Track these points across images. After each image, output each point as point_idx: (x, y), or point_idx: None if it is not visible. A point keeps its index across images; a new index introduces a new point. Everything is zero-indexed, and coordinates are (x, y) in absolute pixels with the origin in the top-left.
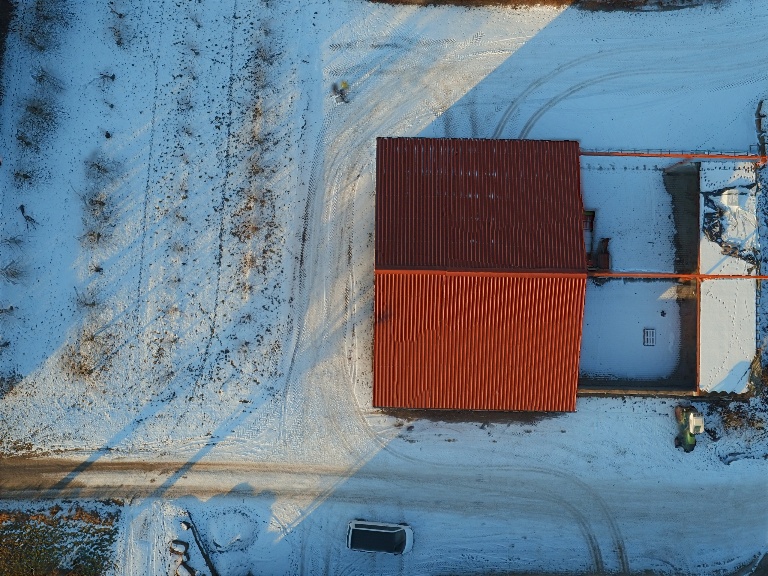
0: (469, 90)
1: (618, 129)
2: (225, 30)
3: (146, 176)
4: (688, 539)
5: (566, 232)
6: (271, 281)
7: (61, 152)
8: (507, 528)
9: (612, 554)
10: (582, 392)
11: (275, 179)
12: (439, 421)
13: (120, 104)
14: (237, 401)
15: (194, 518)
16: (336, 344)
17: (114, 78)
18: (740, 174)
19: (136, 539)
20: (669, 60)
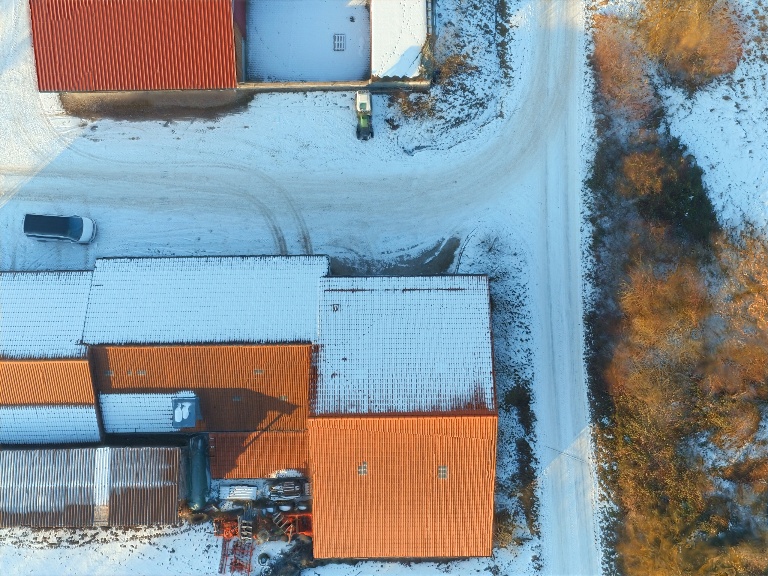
0: None
1: None
2: None
3: None
4: (373, 228)
5: None
6: None
7: None
8: (193, 222)
9: (297, 244)
10: (262, 86)
11: None
12: (123, 120)
13: None
14: None
15: None
16: (24, 53)
17: None
18: None
19: None
20: None
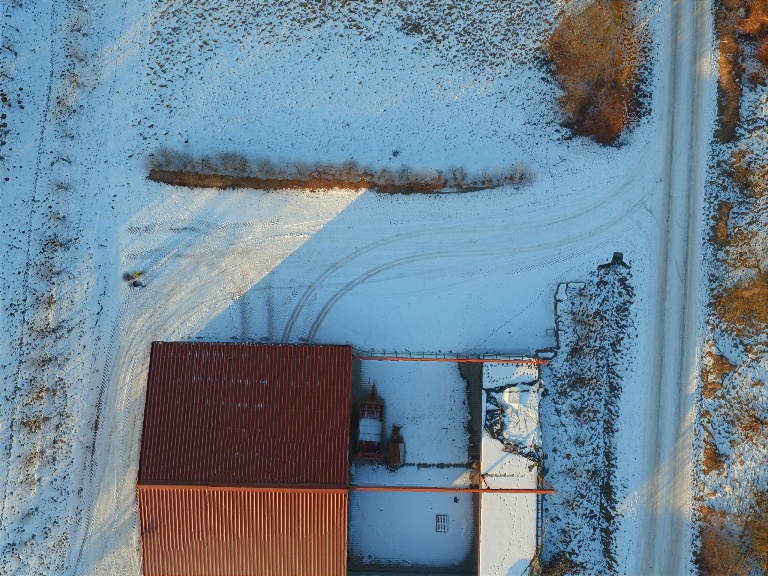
0: (266, 274)
1: (414, 314)
2: (23, 214)
3: None
4: None
5: (331, 444)
6: (61, 472)
7: None
8: None
9: None
10: None
11: (68, 367)
12: None
13: None
14: None
15: None
16: (125, 534)
17: None
18: (523, 371)
19: None
20: (468, 242)
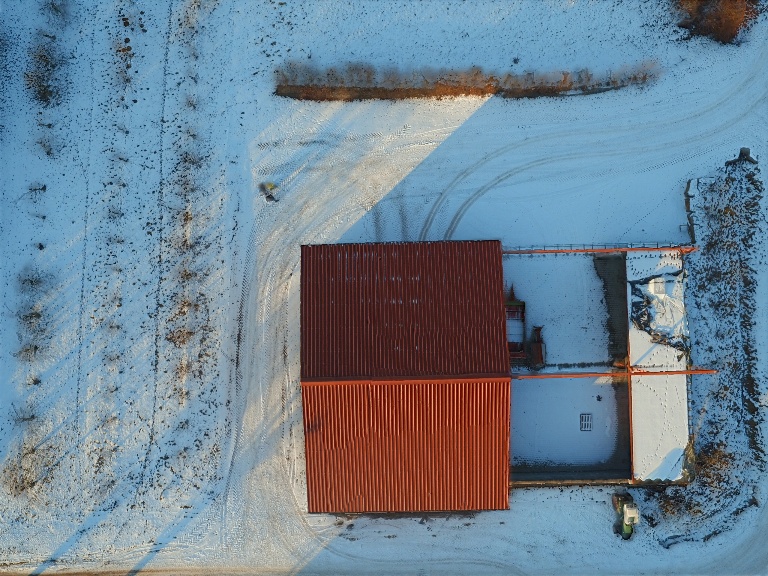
0: (398, 183)
1: (547, 216)
2: (154, 135)
3: (80, 286)
4: None
5: (490, 335)
6: (207, 385)
7: None
8: None
9: None
10: (518, 484)
11: (208, 282)
12: (378, 518)
13: (52, 215)
14: (178, 507)
15: None
16: (274, 445)
17: (45, 189)
18: (666, 261)
19: None
20: (596, 143)
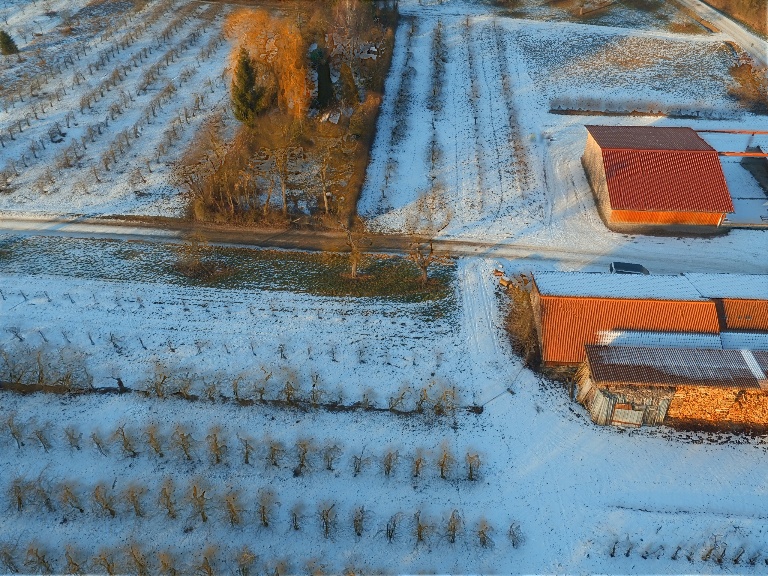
0: None
1: None
2: None
3: None
4: None
5: None
6: None
7: (410, 145)
8: None
9: None
10: (735, 225)
11: (525, 158)
12: (650, 236)
13: None
14: (522, 223)
15: (505, 267)
16: None
17: None
18: None
19: (470, 270)
20: None
